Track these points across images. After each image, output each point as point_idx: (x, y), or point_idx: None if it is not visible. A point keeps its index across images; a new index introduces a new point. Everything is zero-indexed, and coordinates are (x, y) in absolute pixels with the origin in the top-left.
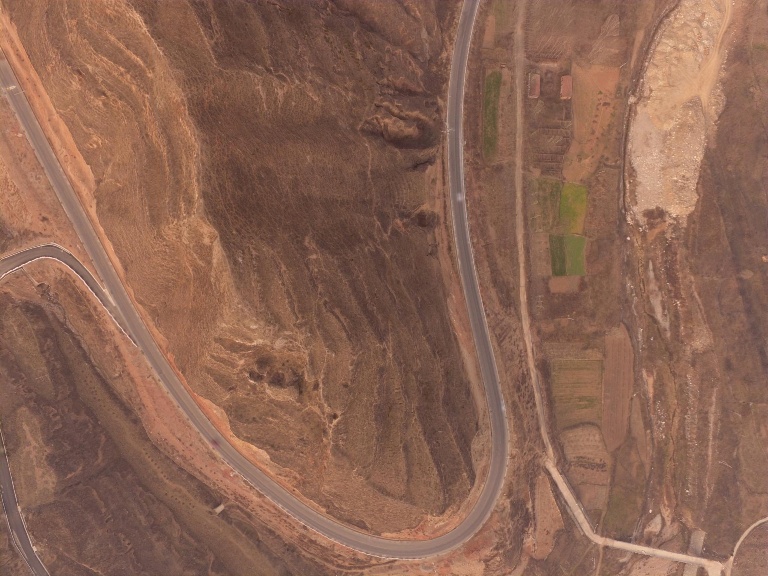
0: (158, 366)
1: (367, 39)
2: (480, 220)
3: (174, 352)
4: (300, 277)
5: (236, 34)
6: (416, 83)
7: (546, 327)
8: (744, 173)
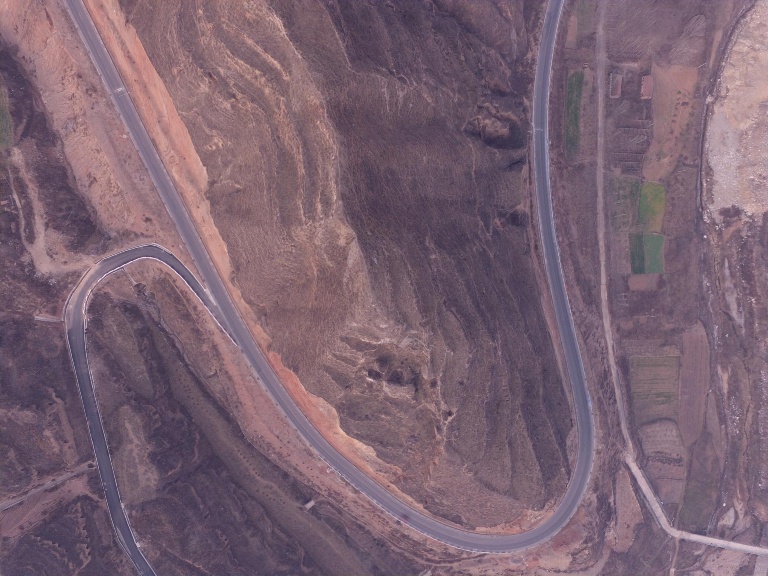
0: (257, 365)
1: (467, 40)
2: (564, 219)
3: (280, 351)
4: (424, 277)
5: (361, 37)
6: (506, 83)
7: (625, 324)
8: None
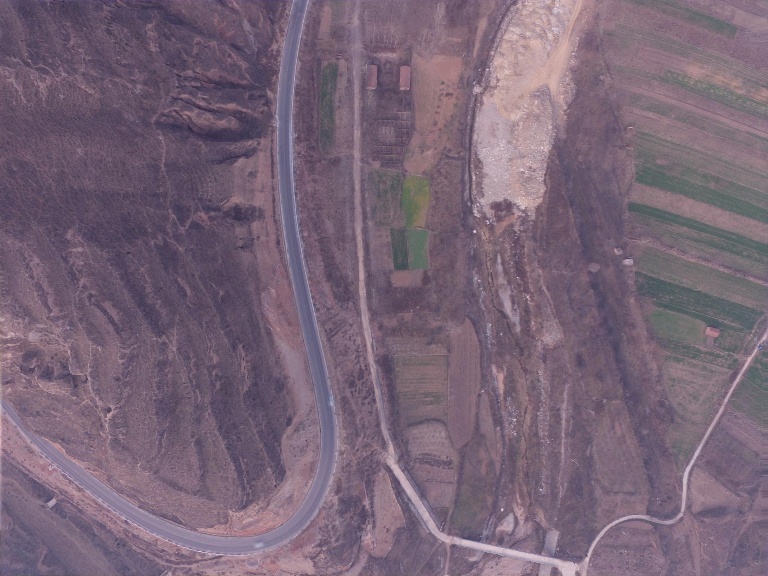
0: None
1: (168, 31)
2: (313, 213)
3: None
4: (56, 270)
5: None
6: (238, 75)
7: (389, 322)
8: (594, 163)
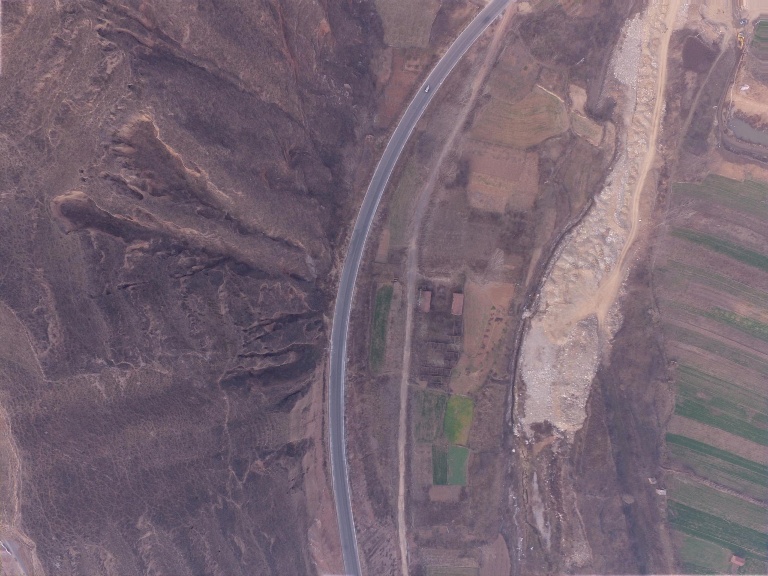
0: None
1: (237, 286)
2: (360, 433)
3: None
4: (127, 563)
5: (78, 330)
6: (297, 308)
7: (424, 533)
8: (635, 395)
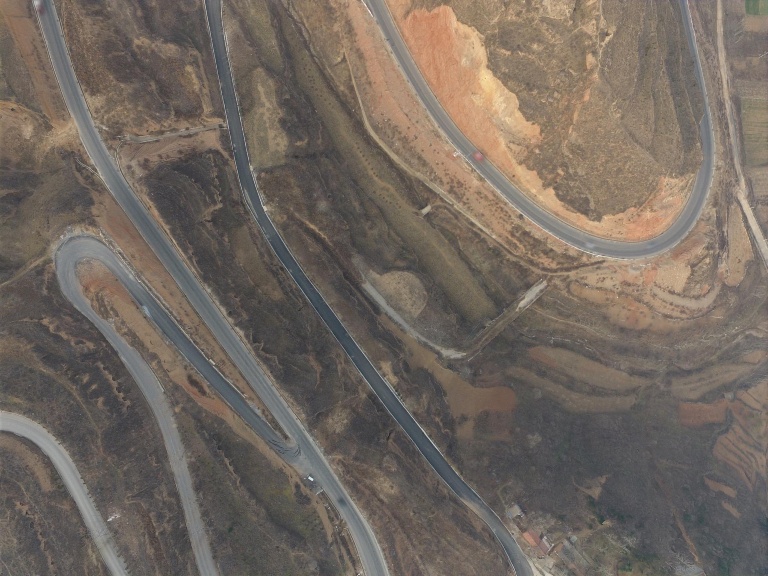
0: (391, 38)
1: None
2: None
3: (424, 2)
4: None
5: None
6: None
7: (738, 64)
8: None
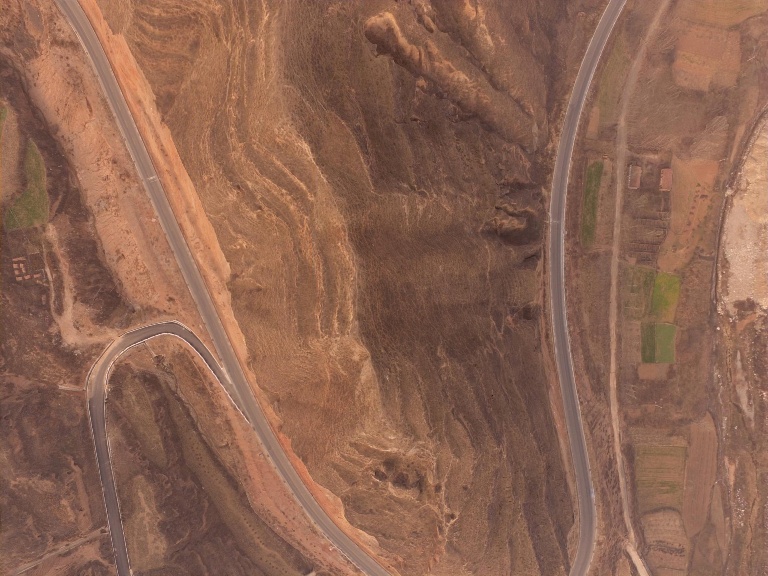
0: (268, 442)
1: (489, 141)
2: (576, 308)
3: (290, 436)
4: (434, 388)
5: (385, 154)
6: (525, 176)
7: (633, 412)
8: None
